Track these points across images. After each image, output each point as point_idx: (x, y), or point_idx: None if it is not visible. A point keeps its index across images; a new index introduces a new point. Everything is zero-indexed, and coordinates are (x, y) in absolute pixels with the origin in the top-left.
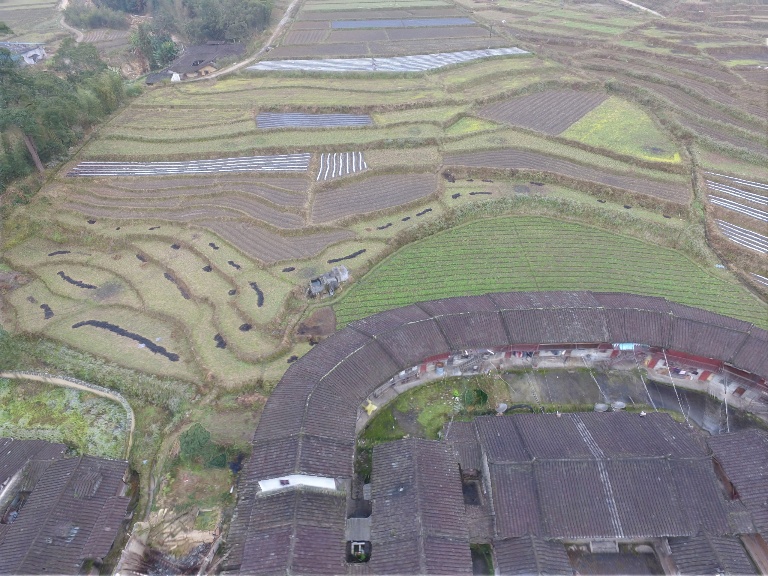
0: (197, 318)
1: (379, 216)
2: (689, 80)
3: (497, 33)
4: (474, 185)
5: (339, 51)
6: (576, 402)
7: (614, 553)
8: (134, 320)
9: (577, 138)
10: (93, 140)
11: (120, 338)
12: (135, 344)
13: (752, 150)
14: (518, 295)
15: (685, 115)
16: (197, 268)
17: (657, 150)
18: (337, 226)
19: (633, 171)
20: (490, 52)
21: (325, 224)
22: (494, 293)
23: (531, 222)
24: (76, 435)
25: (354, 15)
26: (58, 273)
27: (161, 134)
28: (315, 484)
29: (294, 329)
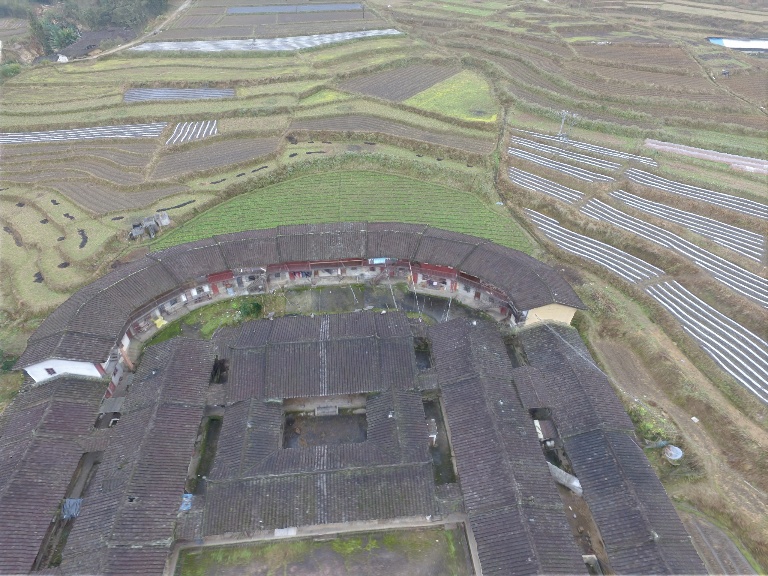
0: (23, 261)
1: (216, 173)
2: (532, 54)
3: (380, 16)
4: (313, 146)
5: (224, 33)
6: (340, 310)
7: (334, 415)
8: None
9: (416, 104)
10: None
11: None
12: None
13: (554, 109)
14: (302, 226)
15: (515, 83)
16: (35, 221)
17: (480, 113)
18: (174, 182)
19: (452, 130)
20: (367, 33)
21: (161, 180)
22: (283, 226)
23: (356, 175)
24: None
25: (252, 1)
26: None
27: (26, 108)
28: (79, 372)
29: (108, 265)
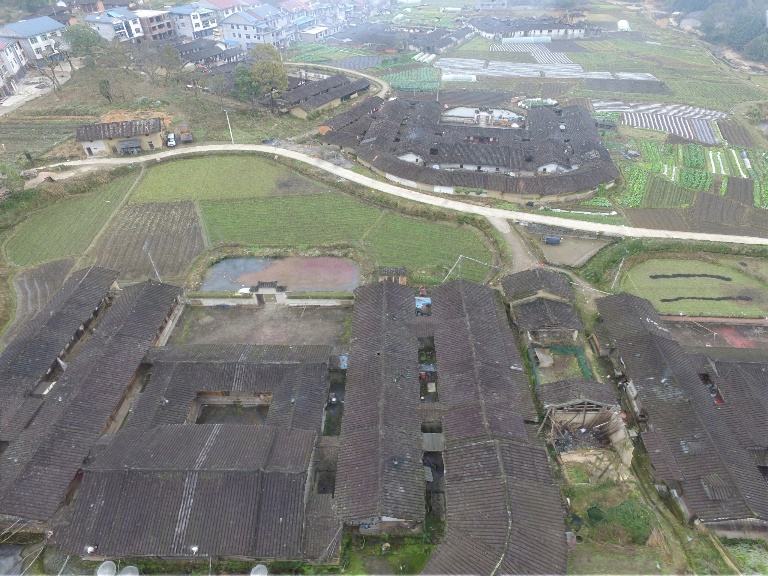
0: None
1: None
2: None
3: None
4: None
5: None
6: None
7: None
8: None
9: None
10: None
11: None
12: None
13: None
14: None
15: None
16: None
17: None
18: None
19: None
20: None
21: None
22: None
23: None
24: None
25: None
26: None
27: None
28: None
29: None
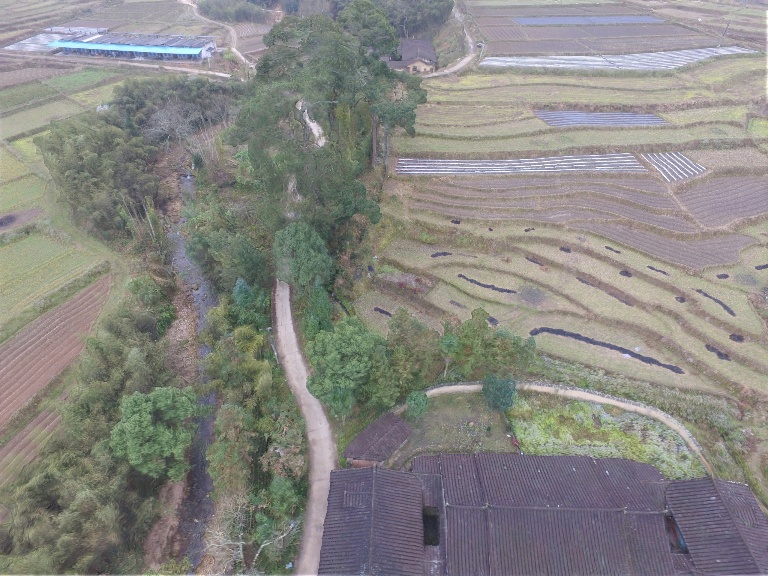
0: (665, 327)
1: (761, 220)
2: None
3: (702, 32)
4: None
5: (558, 48)
6: None
7: None
8: (589, 328)
9: None
10: (390, 136)
11: (595, 347)
12: (618, 354)
13: None
14: None
15: None
16: (613, 273)
17: None
18: (732, 230)
19: None
20: (716, 51)
21: (722, 228)
22: None
23: None
24: (633, 453)
25: (528, 12)
26: (459, 276)
27: (458, 131)
28: None
29: None
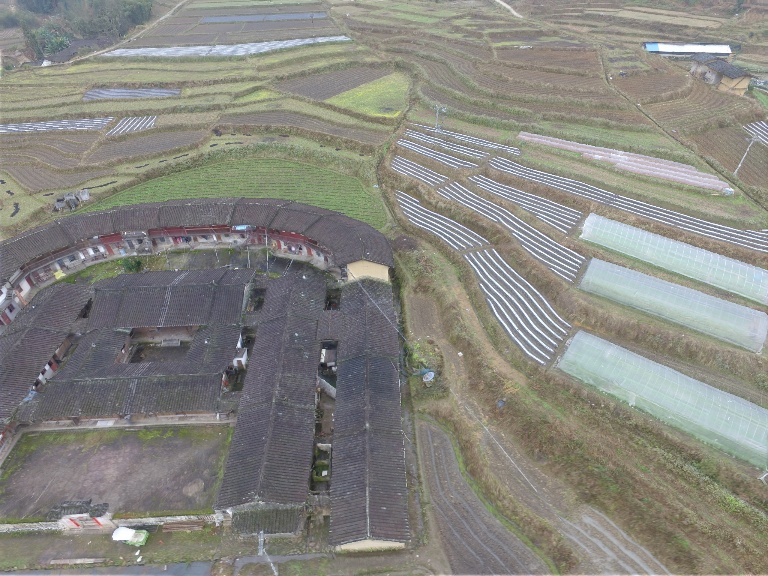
0: None
1: (143, 159)
2: (458, 58)
3: (336, 24)
4: (233, 138)
5: (189, 41)
6: None
7: (176, 346)
8: None
9: (334, 102)
10: None
11: None
12: None
13: (449, 106)
14: (188, 200)
15: (430, 84)
16: None
17: (388, 109)
18: (103, 166)
19: (356, 124)
20: (318, 40)
21: (93, 164)
22: None
23: (264, 163)
24: None
25: (228, 12)
26: None
27: None
28: None
29: None
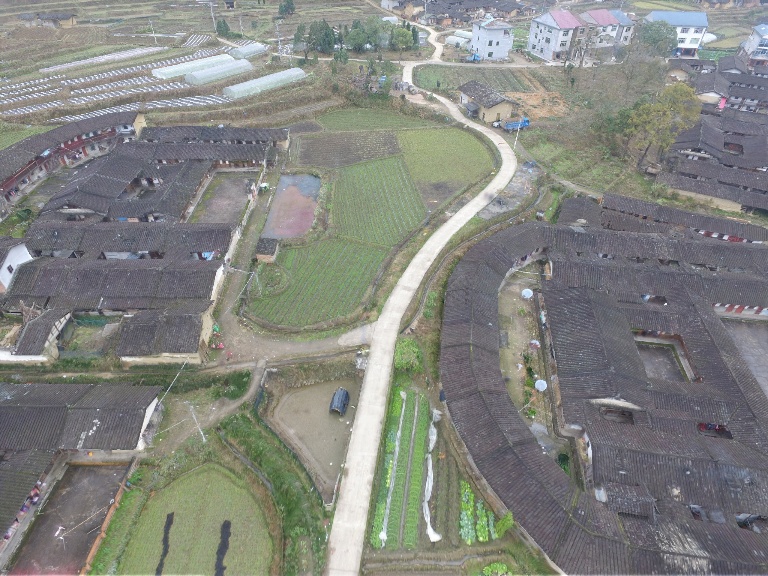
0: None
1: None
2: None
3: None
4: None
5: None
6: None
7: None
8: None
9: None
10: None
11: None
12: None
13: None
14: None
15: None
16: None
17: None
18: None
19: None
20: None
21: None
22: None
23: None
24: None
25: None
26: None
27: None
28: (23, 260)
29: None
